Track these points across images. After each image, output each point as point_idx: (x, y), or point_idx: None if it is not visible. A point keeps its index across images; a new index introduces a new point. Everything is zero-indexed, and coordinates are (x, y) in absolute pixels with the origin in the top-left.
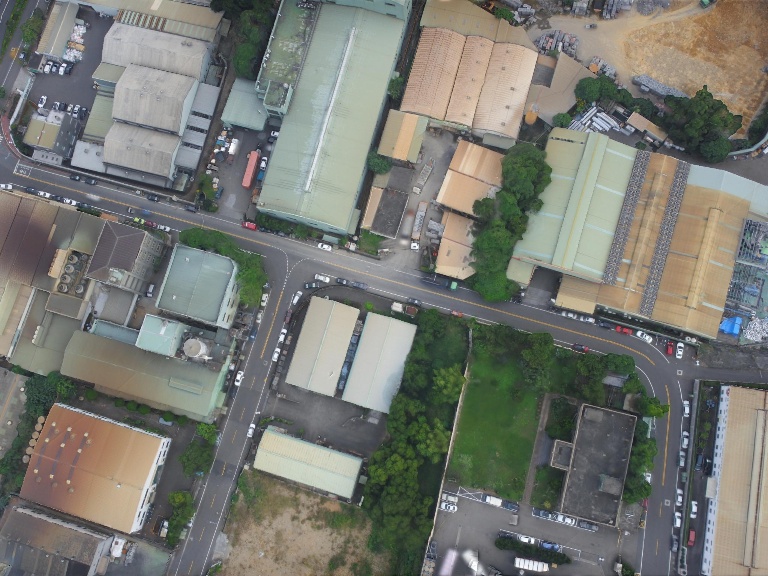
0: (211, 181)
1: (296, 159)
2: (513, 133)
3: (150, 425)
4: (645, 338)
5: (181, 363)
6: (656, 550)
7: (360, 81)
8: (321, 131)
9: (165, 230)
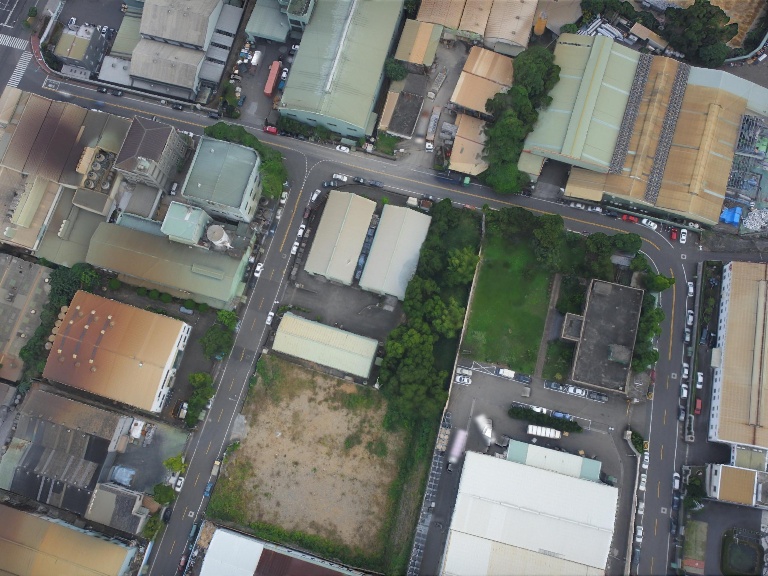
0: (234, 90)
1: (317, 64)
2: (523, 42)
3: (171, 314)
4: (650, 225)
5: (203, 252)
6: (664, 420)
7: None
8: (341, 37)
9: (189, 135)
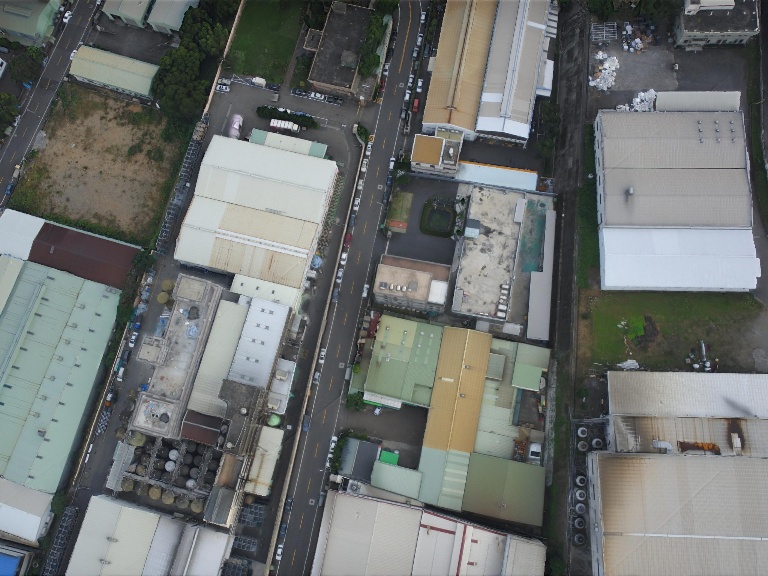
0: None
1: None
2: None
3: None
4: None
5: None
6: (389, 119)
7: None
8: None
9: None
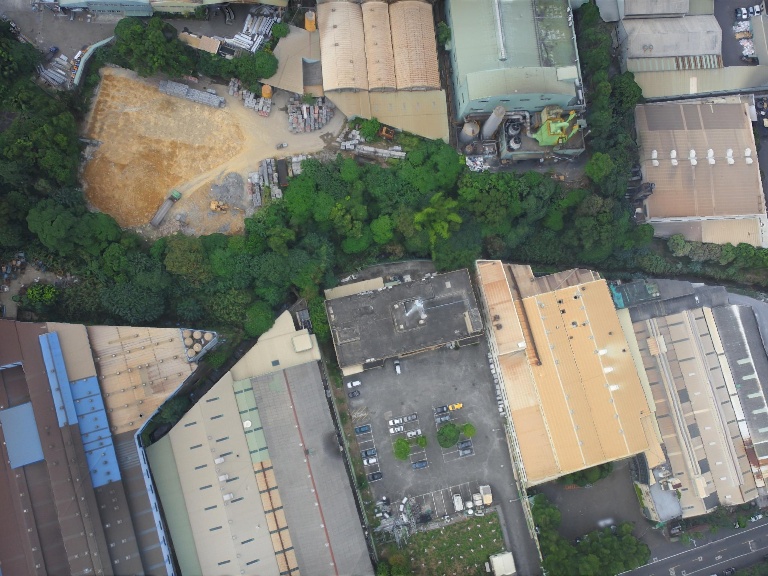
0: None
1: None
2: (322, 8)
3: None
4: None
5: None
6: None
7: (478, 16)
8: None
9: None
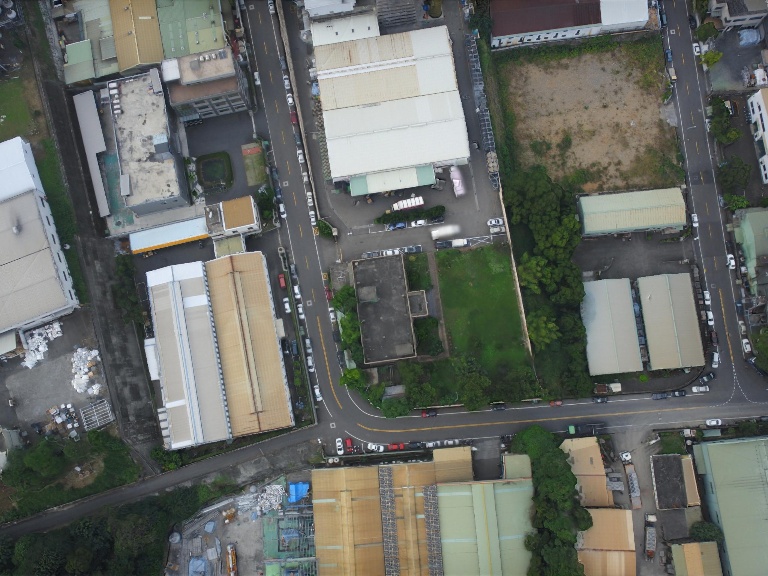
0: None
1: None
2: None
3: None
4: (375, 446)
5: None
6: (307, 260)
7: None
8: None
9: None
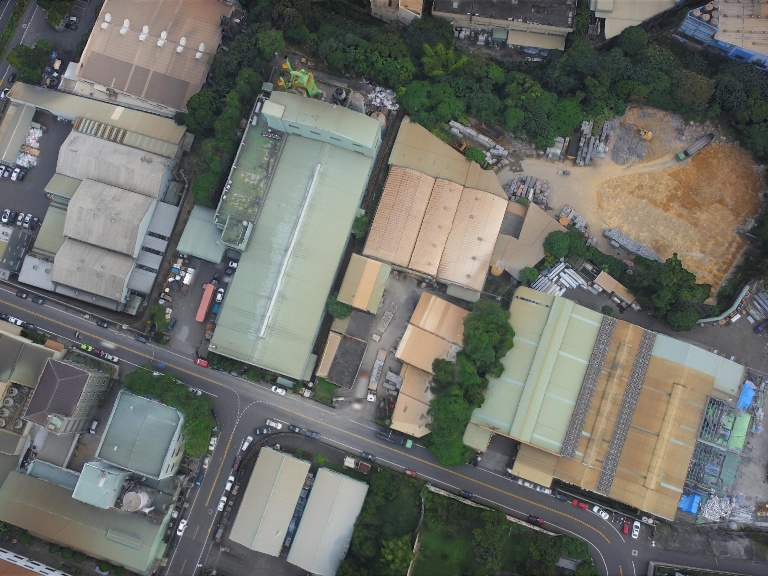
0: (164, 311)
1: (252, 301)
2: (478, 285)
3: (86, 573)
4: (601, 515)
5: (121, 513)
6: None
7: (323, 221)
8: (279, 274)
9: (113, 360)
